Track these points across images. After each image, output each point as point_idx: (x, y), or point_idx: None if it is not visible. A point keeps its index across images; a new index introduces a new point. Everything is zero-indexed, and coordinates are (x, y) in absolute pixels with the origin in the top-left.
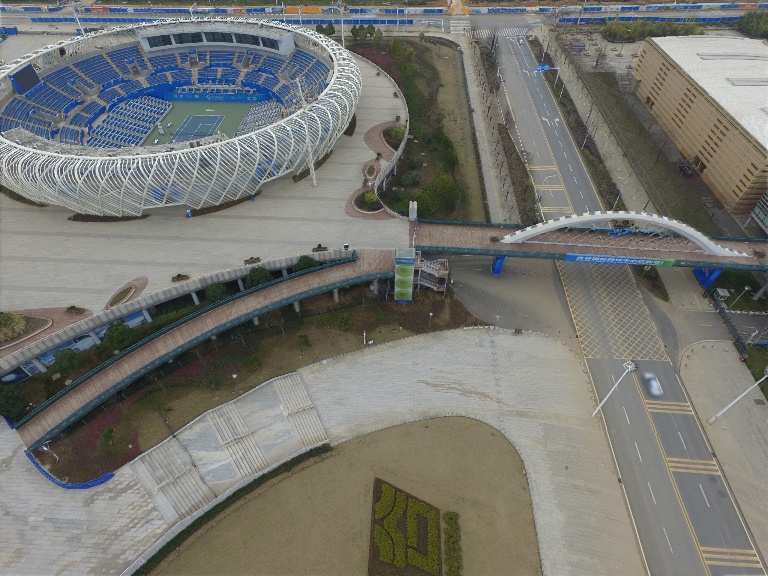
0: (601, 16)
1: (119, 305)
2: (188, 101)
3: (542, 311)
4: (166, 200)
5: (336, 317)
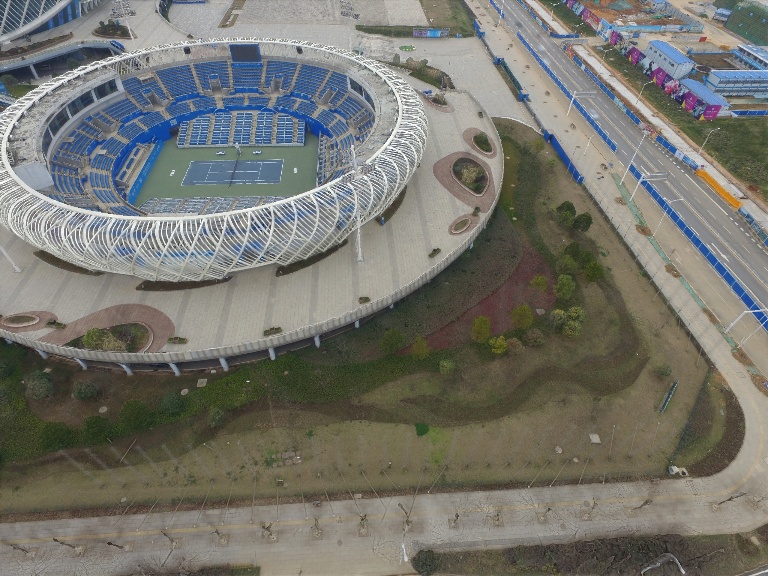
0: None
1: None
2: None
3: None
4: None
5: None
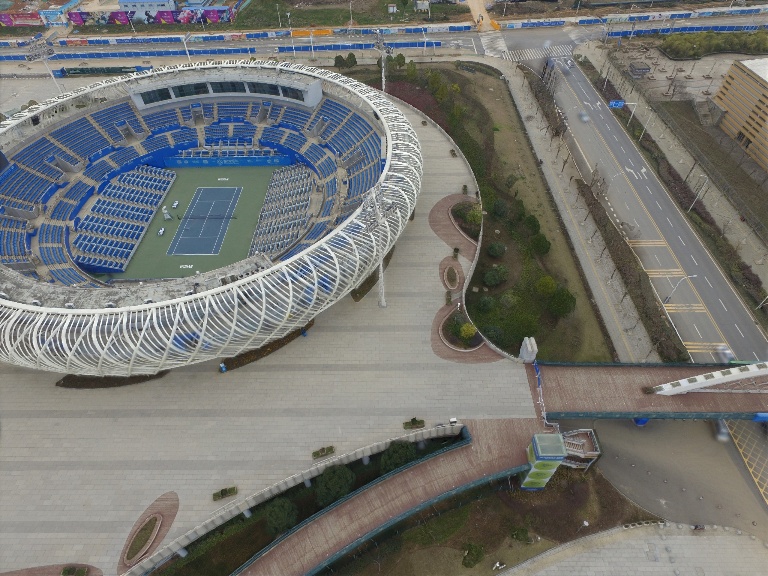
0: (650, 26)
1: (141, 561)
2: (195, 167)
3: (719, 486)
4: (192, 359)
5: (446, 525)
